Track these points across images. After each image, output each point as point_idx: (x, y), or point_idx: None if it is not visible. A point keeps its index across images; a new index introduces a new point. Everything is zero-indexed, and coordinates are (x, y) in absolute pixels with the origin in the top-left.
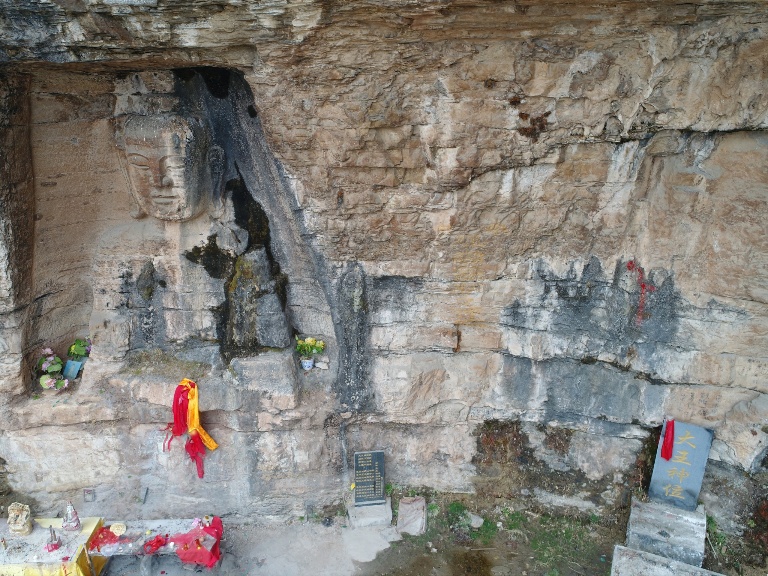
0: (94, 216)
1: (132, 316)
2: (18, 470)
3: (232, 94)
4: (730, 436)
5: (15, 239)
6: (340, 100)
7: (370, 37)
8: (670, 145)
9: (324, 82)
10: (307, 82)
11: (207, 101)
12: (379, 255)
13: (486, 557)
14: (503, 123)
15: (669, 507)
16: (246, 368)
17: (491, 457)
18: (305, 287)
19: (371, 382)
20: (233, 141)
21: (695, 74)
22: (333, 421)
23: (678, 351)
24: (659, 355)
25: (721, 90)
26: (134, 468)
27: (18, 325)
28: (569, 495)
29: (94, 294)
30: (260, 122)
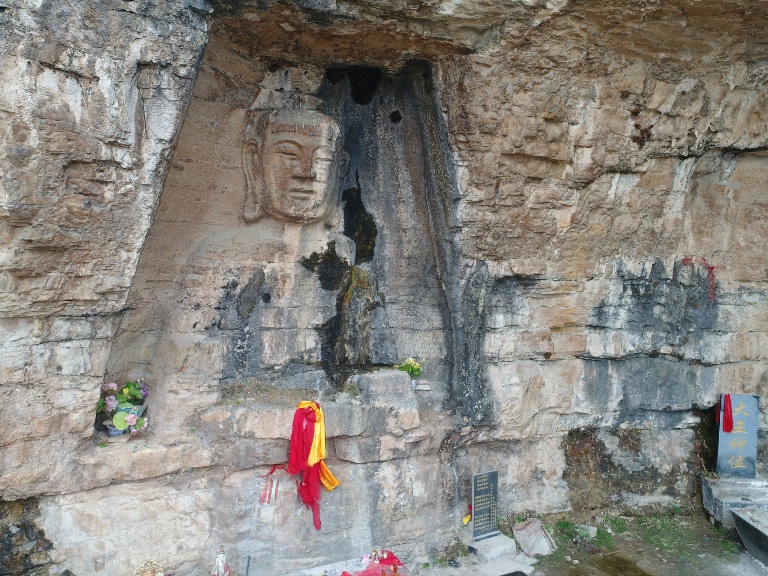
0: (200, 217)
1: (225, 338)
2: (68, 556)
3: (375, 101)
4: (767, 401)
5: None
6: (531, 89)
7: (581, 32)
8: (708, 165)
9: (529, 69)
10: (517, 67)
11: (345, 106)
12: (506, 253)
13: (622, 557)
14: (623, 131)
15: (736, 479)
16: (373, 382)
17: (577, 469)
18: (401, 306)
19: (489, 390)
20: (361, 148)
21: (744, 103)
22: (449, 442)
23: (719, 335)
24: (705, 341)
25: (760, 114)
26: (228, 533)
27: (112, 335)
28: (650, 493)
29: (183, 311)
30: (403, 127)
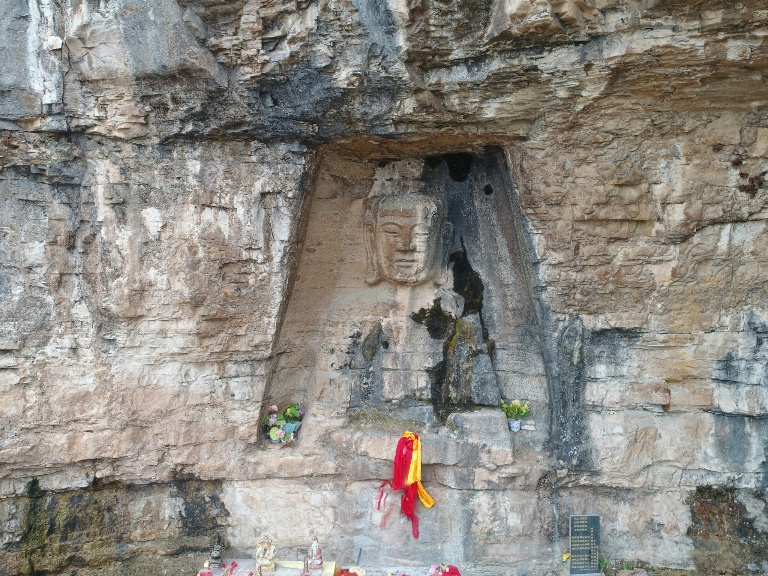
0: (334, 283)
1: (354, 376)
2: (239, 523)
3: (471, 177)
4: None
5: (287, 290)
6: (595, 161)
7: (635, 106)
8: None
9: (586, 145)
10: (572, 146)
11: (446, 185)
12: (600, 308)
13: None
14: (725, 182)
15: None
16: (467, 421)
17: (707, 529)
18: (511, 352)
19: (587, 437)
20: (463, 218)
21: None
22: (547, 481)
23: None
24: None
25: None
26: (347, 527)
27: (266, 374)
28: None
29: (323, 354)
30: (495, 198)
